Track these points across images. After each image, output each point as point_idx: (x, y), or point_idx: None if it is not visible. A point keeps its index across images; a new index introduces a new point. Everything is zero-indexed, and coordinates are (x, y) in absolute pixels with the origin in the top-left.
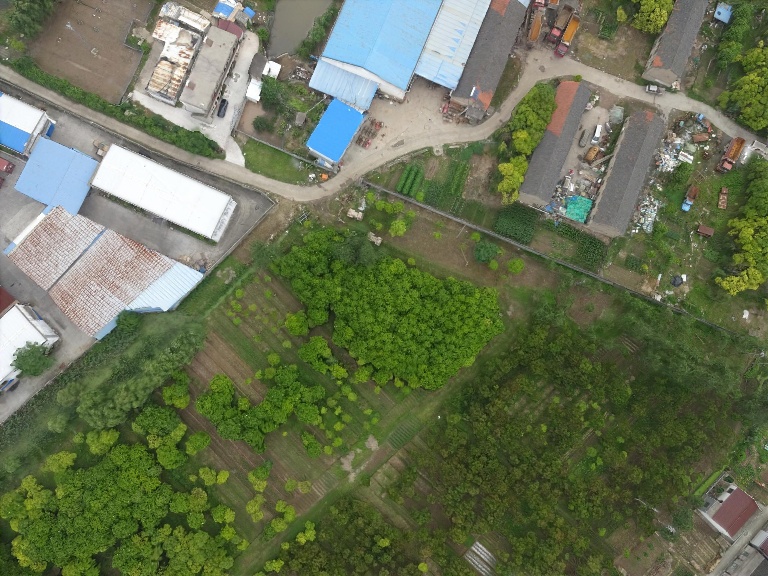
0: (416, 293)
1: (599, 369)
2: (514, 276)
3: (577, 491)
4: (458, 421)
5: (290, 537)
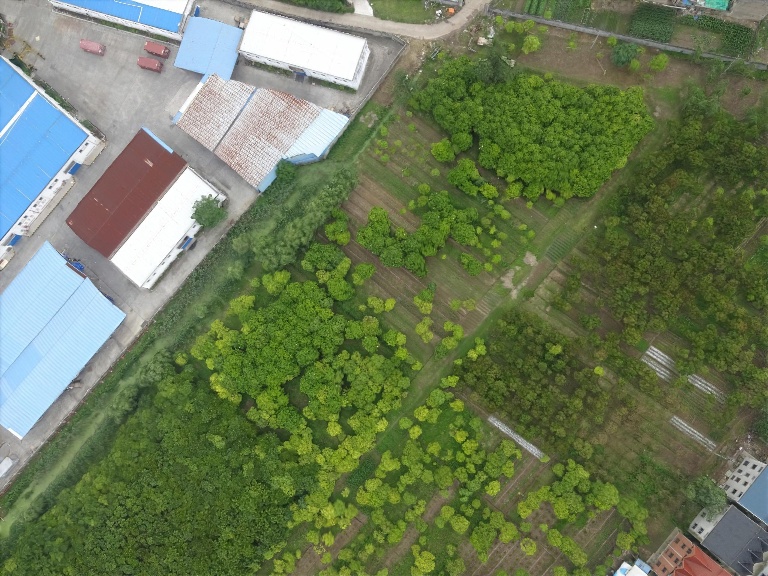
0: (558, 102)
1: (764, 151)
2: (656, 77)
3: (756, 279)
4: (617, 224)
5: (461, 356)
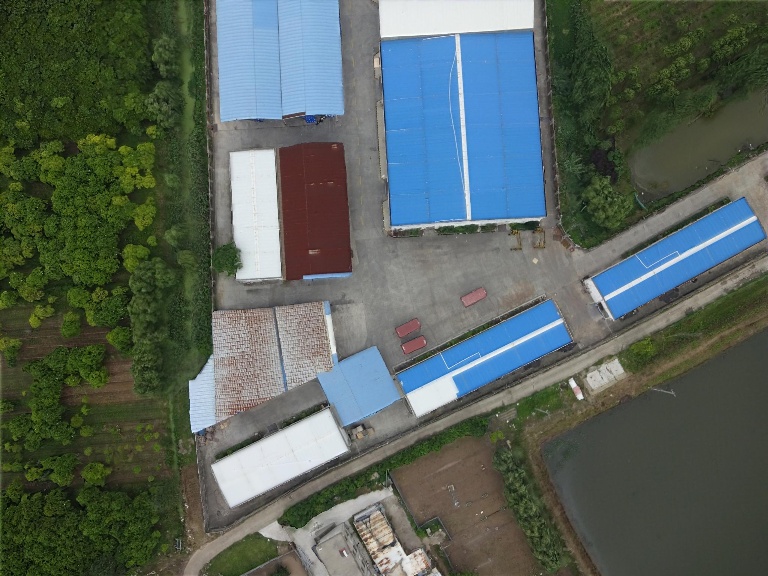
0: None
1: None
2: None
3: None
4: None
5: None
